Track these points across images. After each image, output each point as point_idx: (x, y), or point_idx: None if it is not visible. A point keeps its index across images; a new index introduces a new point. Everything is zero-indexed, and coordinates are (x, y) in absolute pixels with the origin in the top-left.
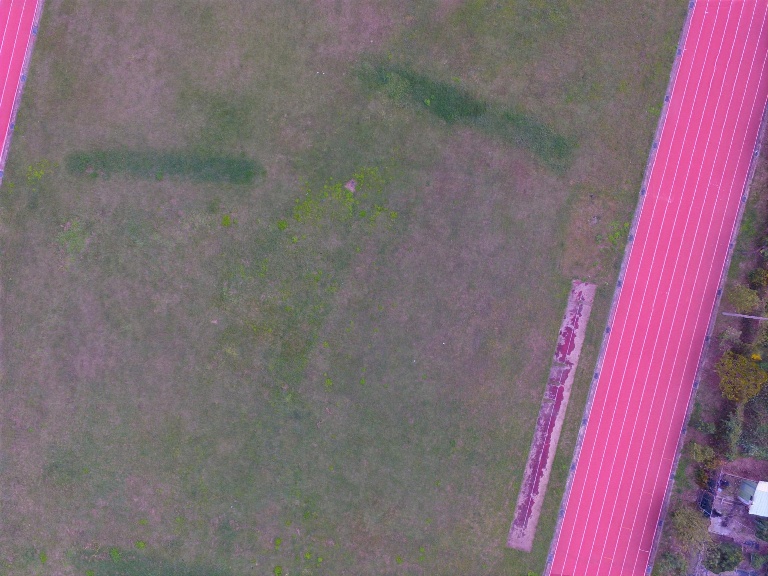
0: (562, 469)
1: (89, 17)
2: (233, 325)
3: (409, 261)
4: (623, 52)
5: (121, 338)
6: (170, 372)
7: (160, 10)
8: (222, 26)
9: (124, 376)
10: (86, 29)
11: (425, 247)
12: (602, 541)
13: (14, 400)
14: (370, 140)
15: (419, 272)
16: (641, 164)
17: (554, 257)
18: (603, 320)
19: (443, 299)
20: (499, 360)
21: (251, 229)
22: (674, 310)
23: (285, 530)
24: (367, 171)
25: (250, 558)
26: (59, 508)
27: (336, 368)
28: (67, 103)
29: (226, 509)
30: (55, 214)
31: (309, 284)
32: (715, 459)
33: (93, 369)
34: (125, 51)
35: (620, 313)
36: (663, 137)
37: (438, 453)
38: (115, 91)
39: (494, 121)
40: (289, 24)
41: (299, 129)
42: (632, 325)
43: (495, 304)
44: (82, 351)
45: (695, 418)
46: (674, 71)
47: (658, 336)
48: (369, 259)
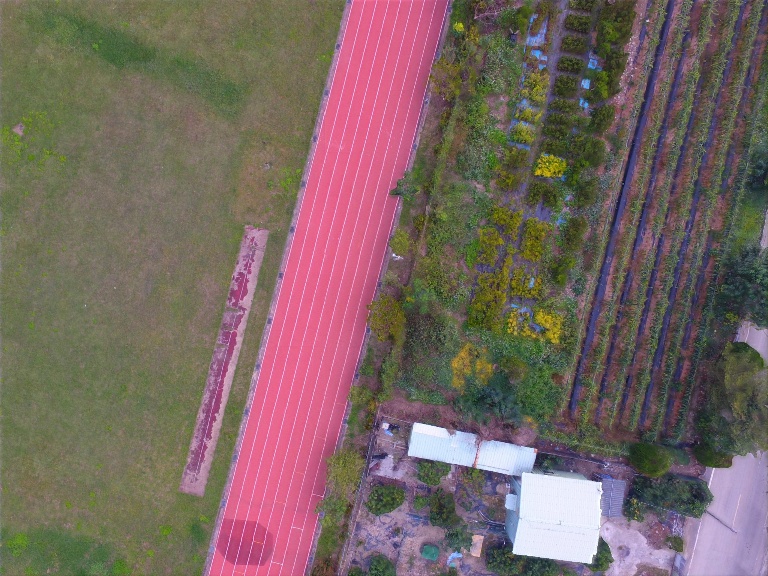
0: (234, 414)
1: None
2: None
3: (79, 205)
4: None
5: None
6: None
7: None
8: None
9: None
10: None
11: (95, 191)
12: (275, 486)
13: None
14: (38, 84)
15: (89, 216)
16: (312, 111)
17: (226, 203)
18: (275, 265)
19: (114, 244)
20: (171, 305)
21: None
22: (346, 256)
23: None
24: (36, 115)
25: None
26: None
27: (5, 312)
28: None
29: None
30: None
31: None
32: (371, 401)
33: None
34: None
35: (293, 259)
36: (334, 85)
37: (109, 398)
38: None
39: (164, 66)
40: None
41: None
42: (305, 271)
43: (167, 249)
44: None
45: (367, 363)
46: (345, 19)
47: (330, 282)
48: (38, 203)
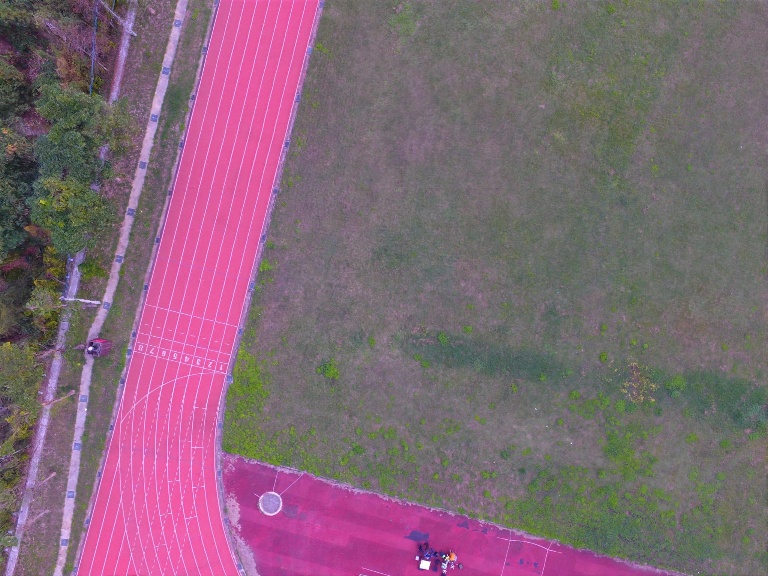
0: None
1: None
2: (561, 109)
3: (736, 46)
4: None
5: (450, 122)
6: (498, 156)
7: None
8: None
9: (453, 160)
10: None
11: (753, 32)
12: None
13: (344, 183)
14: None
15: (746, 57)
16: None
17: None
18: None
19: None
20: None
21: (580, 13)
22: None
23: (610, 316)
24: None
25: (575, 344)
26: (387, 292)
27: (663, 154)
28: None
29: (552, 294)
30: None
31: (637, 69)
32: None
33: (422, 153)
34: None
35: None
36: None
37: (764, 240)
38: None
39: None
40: None
41: None
42: None
43: None
44: (411, 135)
45: None
46: None
47: None
48: (696, 44)
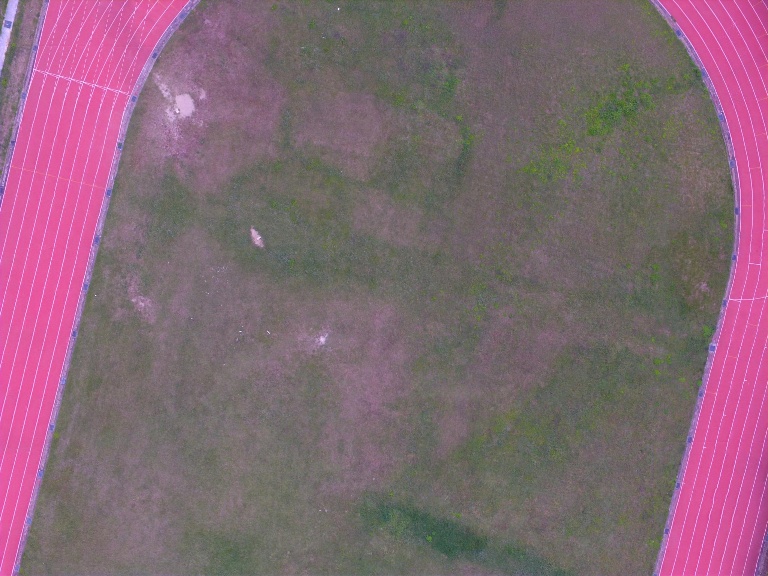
0: None
1: (94, 460)
2: None
3: None
4: (622, 486)
5: None
6: None
7: (165, 452)
8: (226, 467)
9: None
10: (91, 472)
11: None
12: None
13: None
14: (372, 575)
15: None
16: None
17: None
18: None
19: None
20: None
21: None
22: None
23: None
24: None
25: None
26: None
27: None
28: (72, 545)
29: None
30: None
31: None
32: None
33: None
34: (130, 493)
35: None
36: (663, 569)
37: None
38: (120, 532)
39: (495, 555)
40: (292, 464)
41: (302, 566)
42: None
43: None
44: None
45: None
46: (673, 504)
47: None
48: None
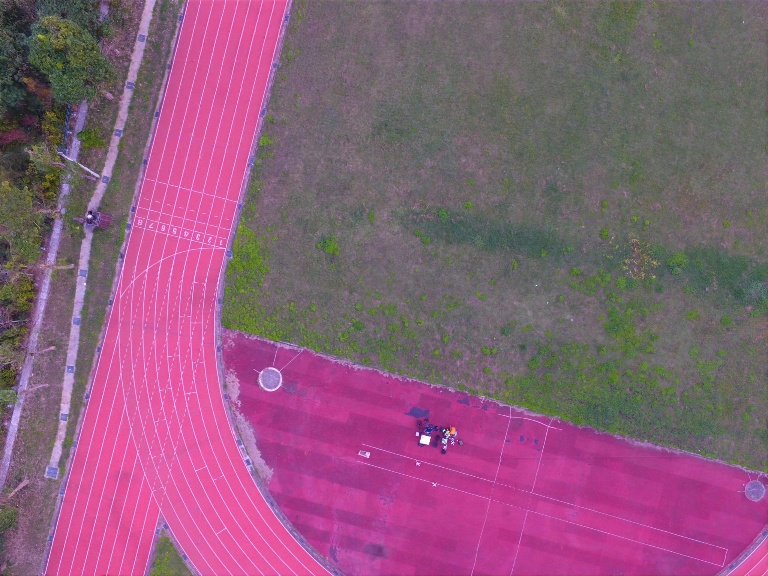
0: None
1: None
2: None
3: None
4: None
5: None
6: (499, 31)
7: None
8: None
9: (453, 34)
10: None
11: None
12: None
13: (345, 57)
14: None
15: None
16: None
17: None
18: None
19: None
20: None
21: None
22: None
23: (612, 193)
24: None
25: (576, 221)
26: (387, 168)
27: (664, 29)
28: None
29: (553, 170)
30: None
31: None
32: None
33: (422, 27)
34: None
35: None
36: None
37: (766, 116)
38: None
39: None
40: None
41: None
42: None
43: None
44: (412, 9)
45: None
46: None
47: None
48: None
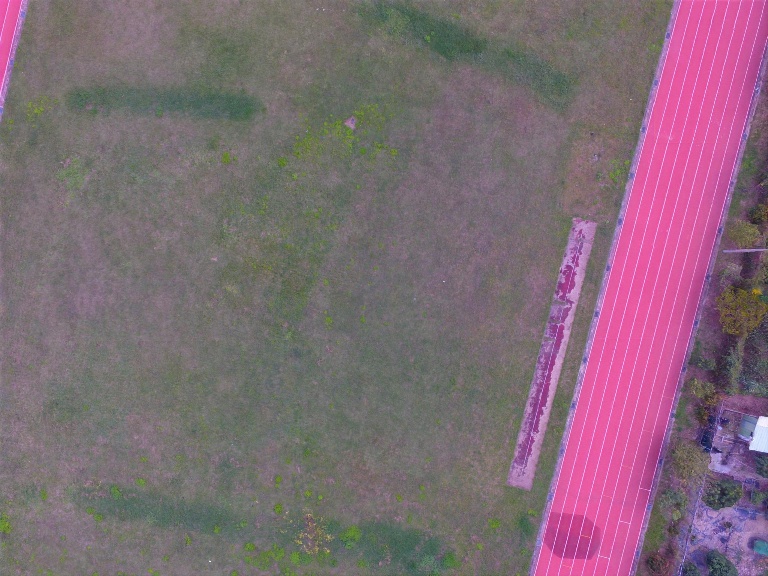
0: (562, 407)
1: None
2: (233, 262)
3: (409, 199)
4: None
5: (121, 275)
6: (170, 309)
7: None
8: None
9: (124, 313)
10: None
11: (425, 185)
12: (602, 479)
13: (14, 337)
14: (370, 77)
15: (419, 210)
16: (642, 101)
17: (554, 195)
18: (603, 258)
19: (443, 237)
20: (499, 298)
21: (251, 166)
22: (675, 248)
23: (285, 468)
24: (367, 108)
25: (250, 496)
26: (59, 445)
27: (336, 306)
28: (67, 39)
29: (226, 447)
30: (55, 151)
31: (309, 222)
32: (715, 394)
33: (93, 306)
34: None
35: (620, 251)
36: (664, 74)
37: (438, 391)
38: (115, 27)
39: (494, 58)
40: None
41: (299, 66)
42: (632, 263)
43: (495, 242)
44: (82, 288)
45: (695, 356)
46: (675, 8)
47: (658, 274)
48: (369, 197)
